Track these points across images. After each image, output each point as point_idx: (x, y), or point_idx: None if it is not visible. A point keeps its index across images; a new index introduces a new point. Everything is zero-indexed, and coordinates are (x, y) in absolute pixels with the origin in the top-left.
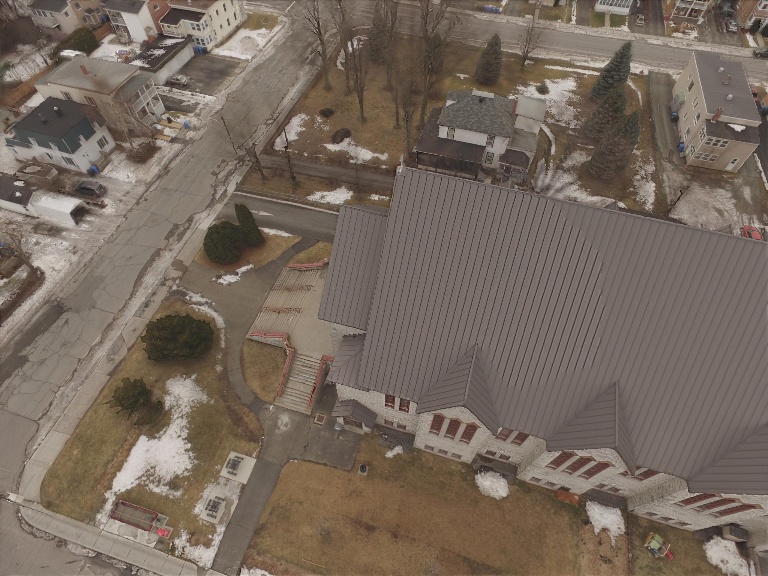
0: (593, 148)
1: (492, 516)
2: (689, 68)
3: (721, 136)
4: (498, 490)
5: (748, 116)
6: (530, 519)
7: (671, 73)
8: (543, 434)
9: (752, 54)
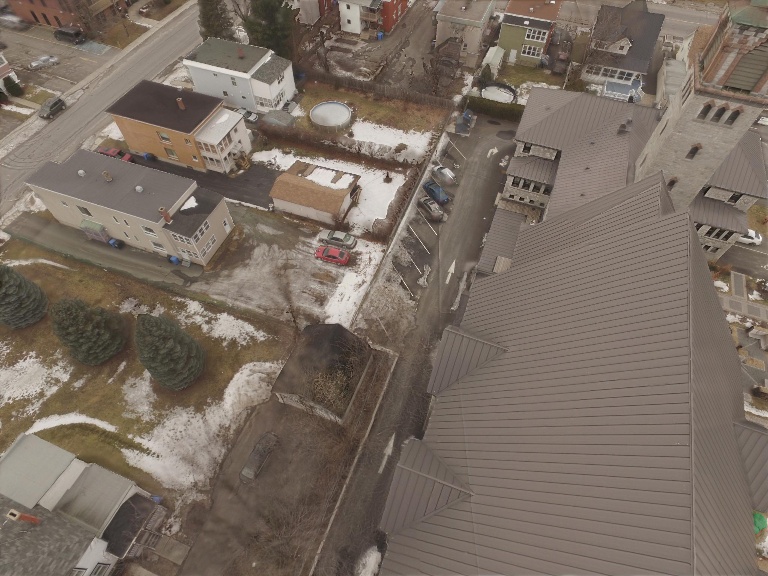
0: (126, 363)
1: None
2: (49, 198)
3: (197, 225)
4: None
5: (180, 188)
6: None
7: (24, 209)
8: None
9: (43, 120)
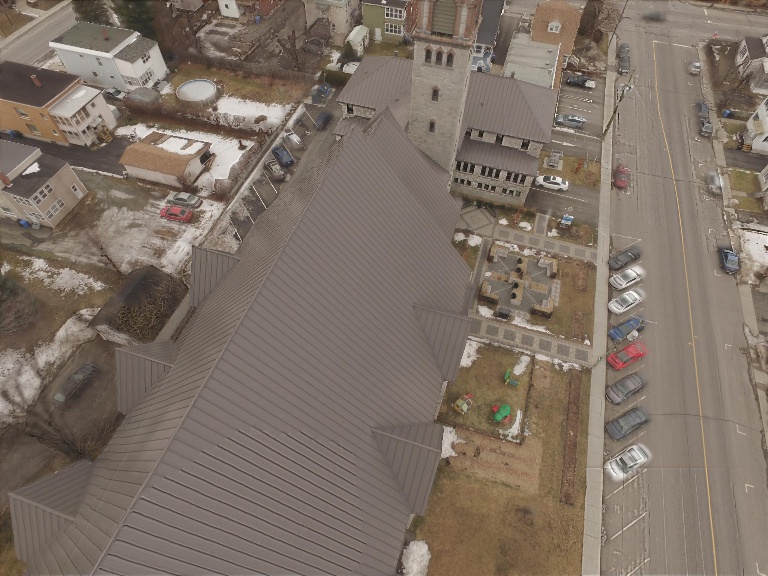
0: None
1: (448, 567)
2: None
3: (37, 187)
4: (422, 555)
5: (23, 155)
6: (448, 521)
7: None
8: (406, 517)
9: None
